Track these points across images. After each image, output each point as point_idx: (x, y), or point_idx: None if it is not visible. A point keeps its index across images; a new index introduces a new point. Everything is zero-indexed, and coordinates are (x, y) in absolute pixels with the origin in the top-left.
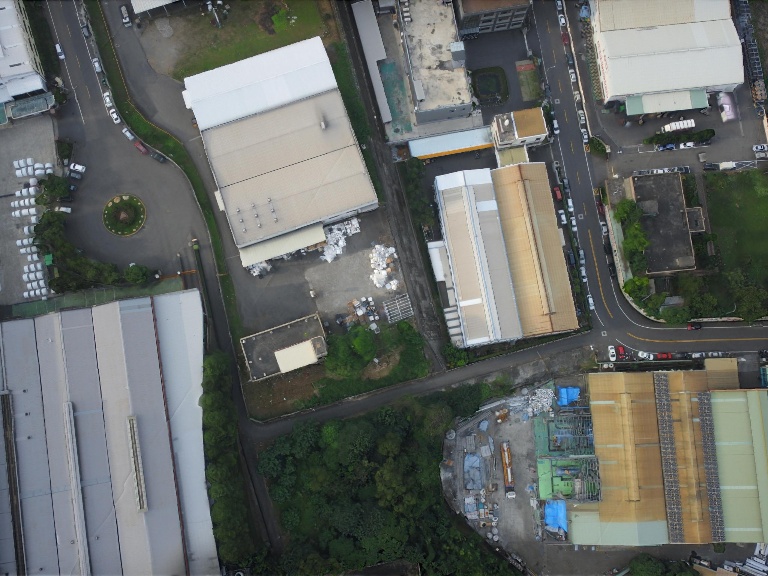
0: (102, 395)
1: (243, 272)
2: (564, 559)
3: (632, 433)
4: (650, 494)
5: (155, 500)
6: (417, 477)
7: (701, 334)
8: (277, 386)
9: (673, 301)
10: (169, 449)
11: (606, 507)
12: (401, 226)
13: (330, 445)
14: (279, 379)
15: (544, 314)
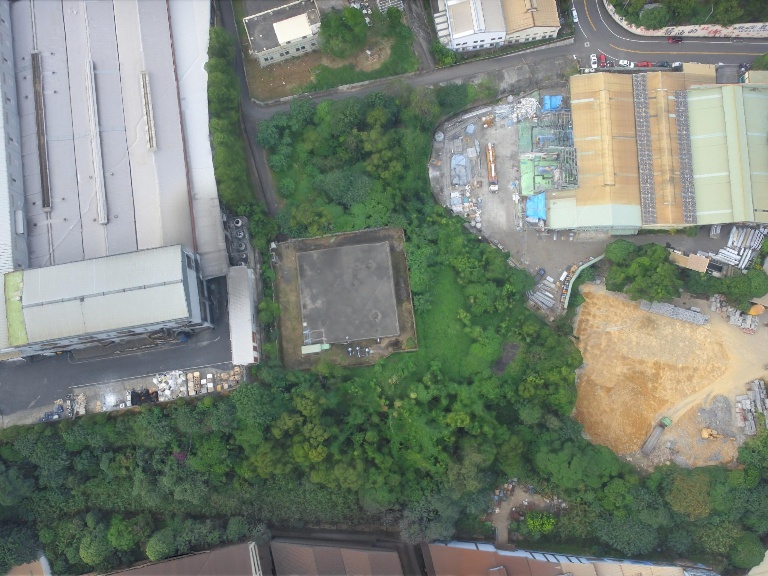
0: (119, 59)
1: None
2: (543, 248)
3: (609, 125)
4: (625, 181)
5: (163, 143)
6: (402, 143)
7: (682, 47)
8: (277, 71)
9: None
10: (177, 104)
11: (583, 193)
12: None
13: (323, 119)
14: (279, 65)
15: (527, 11)
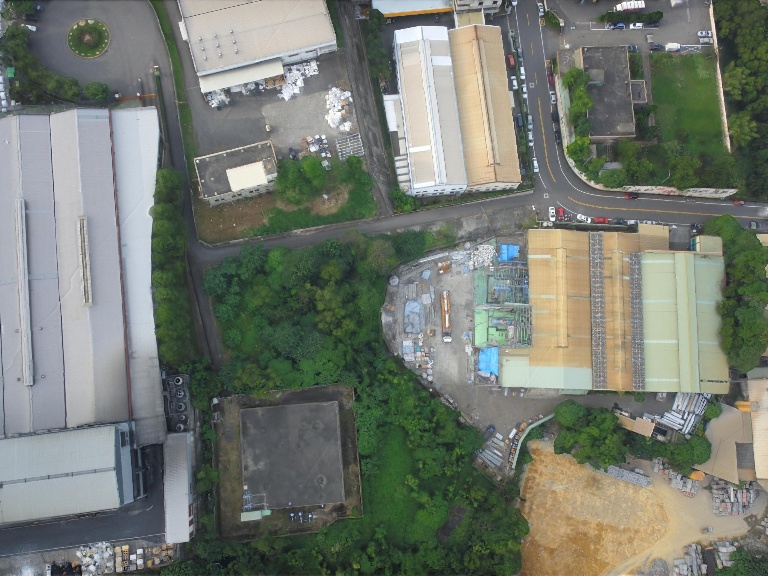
0: (55, 197)
1: (202, 103)
2: (494, 403)
3: (565, 285)
4: (578, 343)
5: (100, 297)
6: (356, 302)
7: (637, 204)
8: (228, 212)
9: (612, 166)
10: (117, 252)
11: (536, 352)
12: (359, 75)
13: (275, 269)
14: (230, 206)
15: (489, 165)
